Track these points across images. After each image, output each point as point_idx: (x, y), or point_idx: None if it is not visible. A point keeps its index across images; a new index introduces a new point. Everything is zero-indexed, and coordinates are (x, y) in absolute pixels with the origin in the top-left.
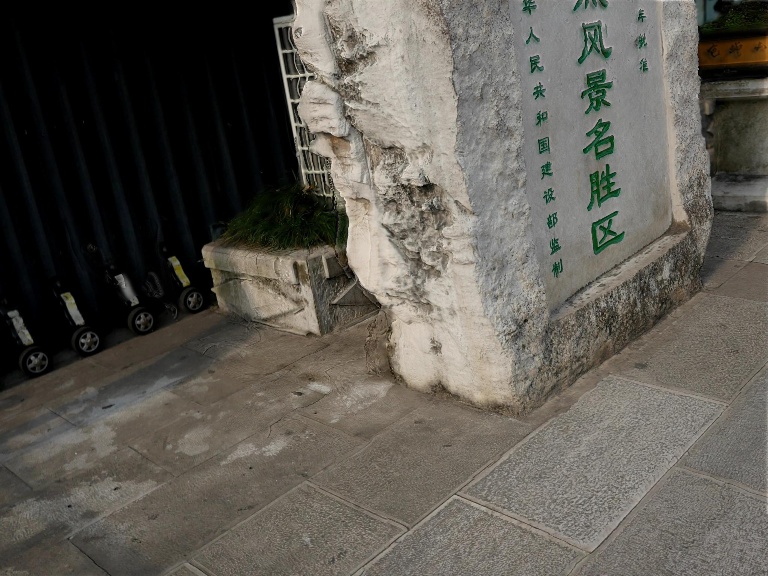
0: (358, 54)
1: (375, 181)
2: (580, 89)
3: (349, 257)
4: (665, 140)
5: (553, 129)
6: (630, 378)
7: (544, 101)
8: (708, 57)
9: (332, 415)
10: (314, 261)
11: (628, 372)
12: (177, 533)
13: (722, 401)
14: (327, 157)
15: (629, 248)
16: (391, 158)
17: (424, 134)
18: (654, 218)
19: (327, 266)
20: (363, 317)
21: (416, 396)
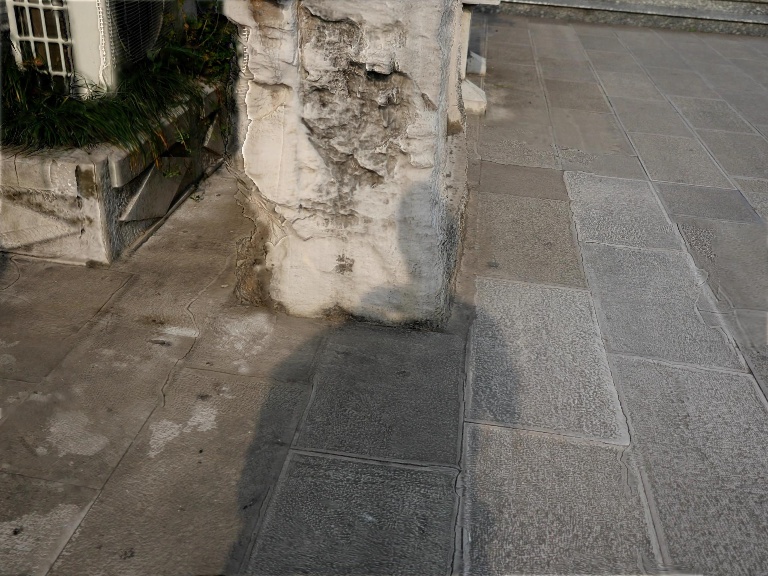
0: None
1: (306, 63)
2: None
3: (244, 160)
4: None
5: None
6: (497, 277)
7: None
8: None
9: (230, 361)
10: (103, 164)
11: (489, 271)
12: (189, 562)
13: (585, 289)
14: (244, 25)
15: None
16: (335, 35)
17: (402, 9)
18: None
19: (115, 171)
20: (146, 235)
21: (308, 323)
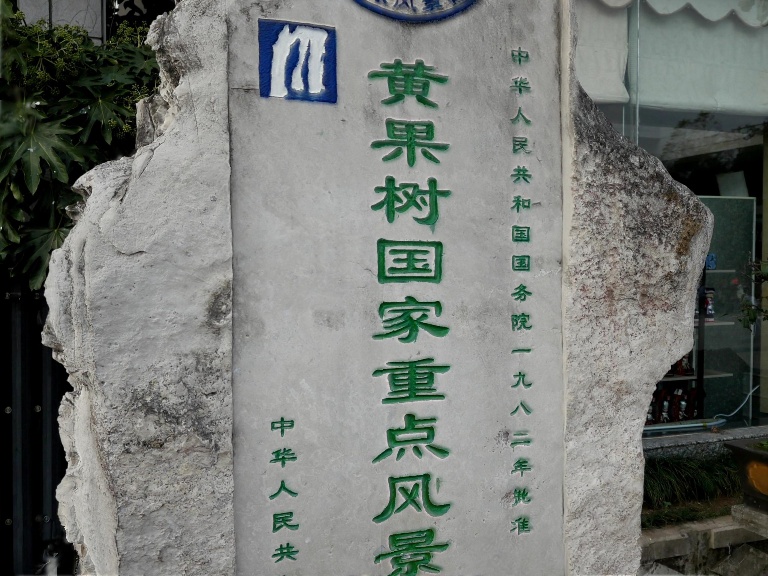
0: None
1: None
2: (373, 552)
3: None
4: None
5: None
6: None
7: (293, 565)
8: None
9: None
10: None
11: None
12: None
13: None
14: None
15: None
16: None
17: None
18: None
19: None
20: None
21: None
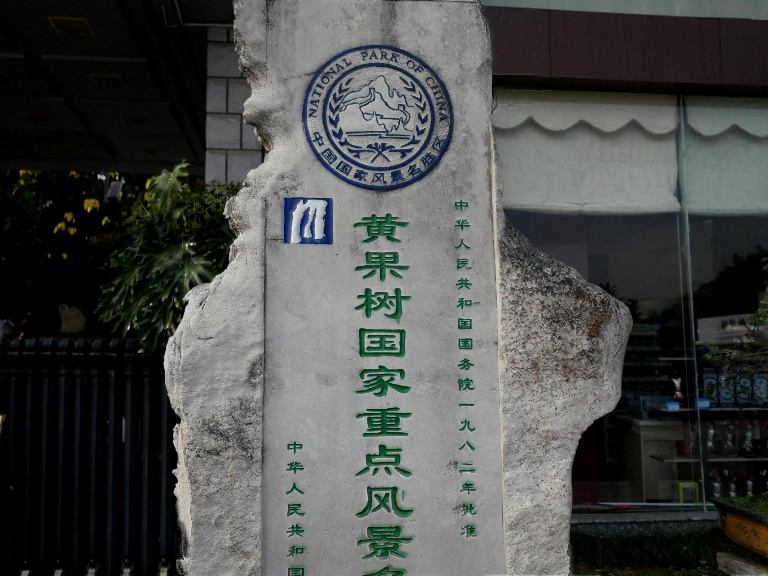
0: None
1: None
2: (356, 538)
3: None
4: None
5: (312, 563)
6: None
7: (301, 539)
8: (743, 537)
9: None
10: None
11: None
12: None
13: None
14: None
15: None
16: None
17: None
18: None
19: None
20: None
21: None
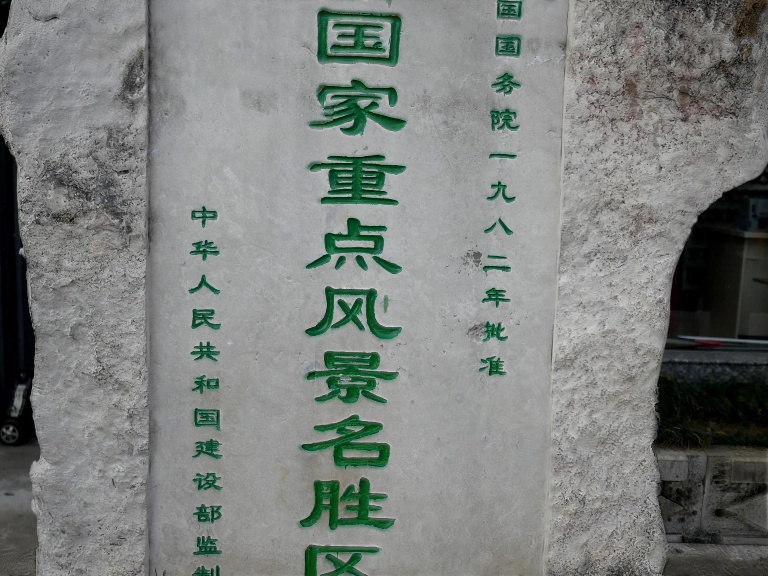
0: None
1: None
2: (307, 367)
3: None
4: (542, 484)
5: (233, 403)
6: None
7: (214, 366)
8: None
9: None
10: None
11: None
12: None
13: None
14: None
15: None
16: None
17: None
18: None
19: None
20: None
21: None
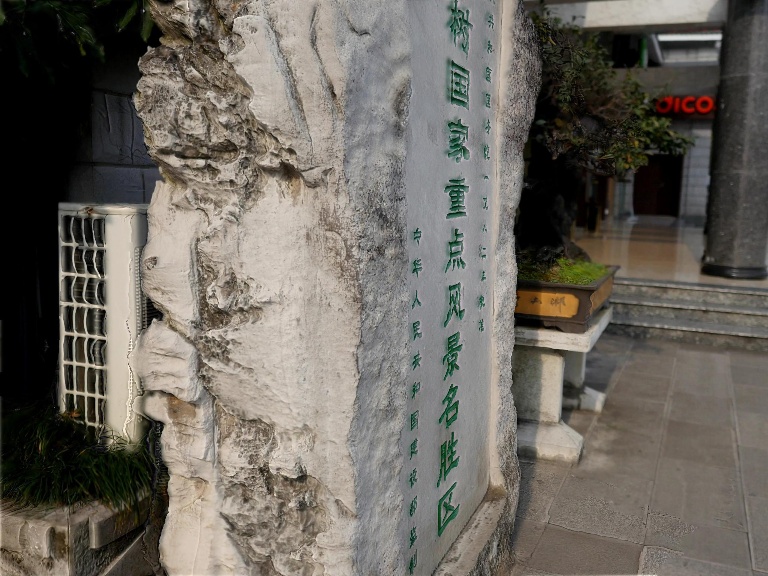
0: (235, 305)
1: (222, 458)
2: (443, 354)
3: (162, 551)
4: (489, 400)
5: (422, 401)
6: None
7: (419, 371)
8: None
9: None
10: (78, 526)
11: None
12: None
13: None
14: (158, 421)
15: (461, 521)
16: (250, 433)
17: (308, 414)
18: (478, 483)
19: (94, 532)
20: None
21: None
